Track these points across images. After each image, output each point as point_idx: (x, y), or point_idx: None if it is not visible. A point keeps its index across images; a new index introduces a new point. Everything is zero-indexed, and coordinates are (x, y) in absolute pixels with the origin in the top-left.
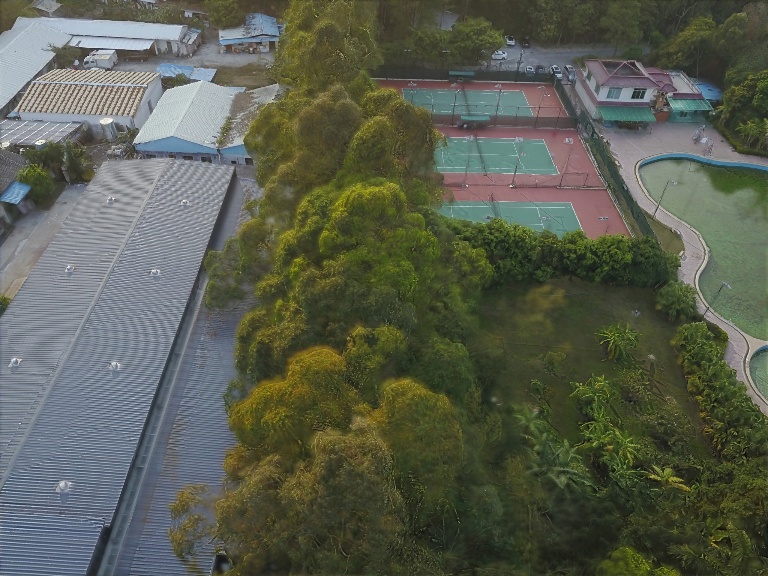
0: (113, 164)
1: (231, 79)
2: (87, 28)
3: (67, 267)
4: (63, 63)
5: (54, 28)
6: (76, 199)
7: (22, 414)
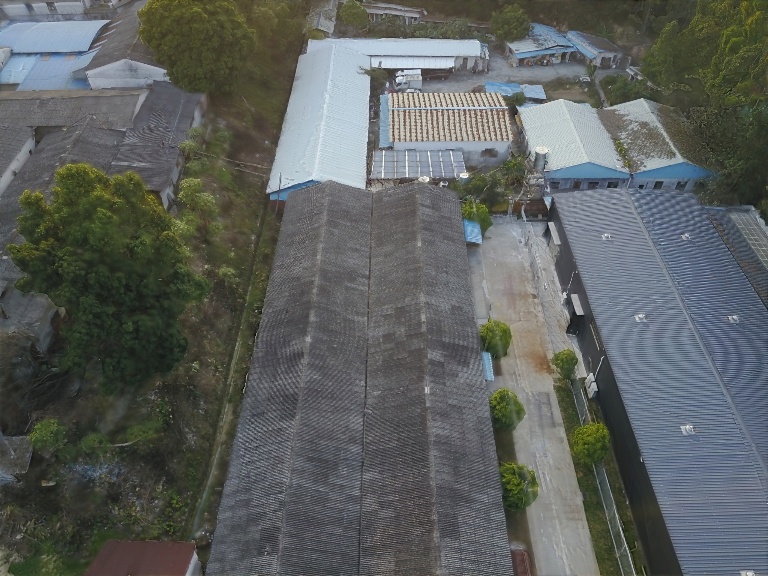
0: (567, 196)
1: (549, 94)
2: (383, 48)
3: (637, 316)
4: (377, 86)
5: (351, 49)
6: (498, 233)
7: (759, 492)
